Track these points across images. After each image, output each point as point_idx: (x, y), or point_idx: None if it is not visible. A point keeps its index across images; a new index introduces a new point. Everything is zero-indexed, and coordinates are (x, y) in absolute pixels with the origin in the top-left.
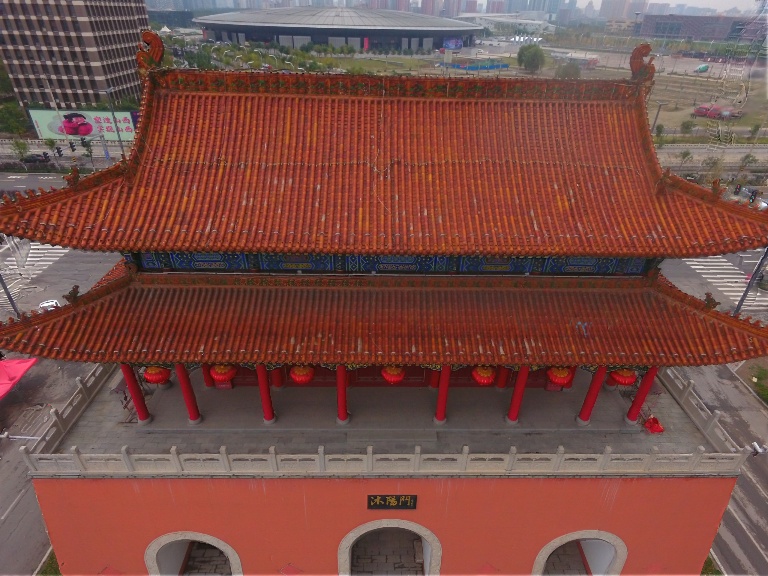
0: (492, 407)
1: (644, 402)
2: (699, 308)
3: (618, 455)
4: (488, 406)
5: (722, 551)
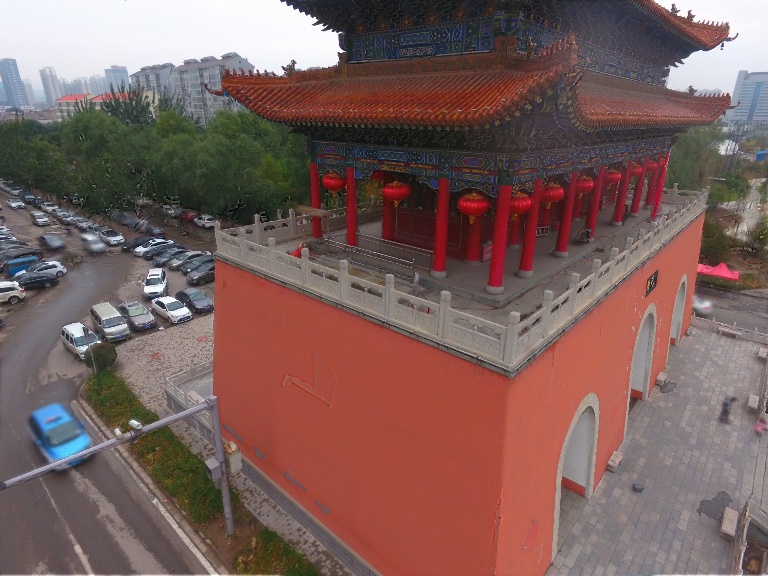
0: None
1: None
2: (297, 79)
3: None
4: None
5: (158, 533)
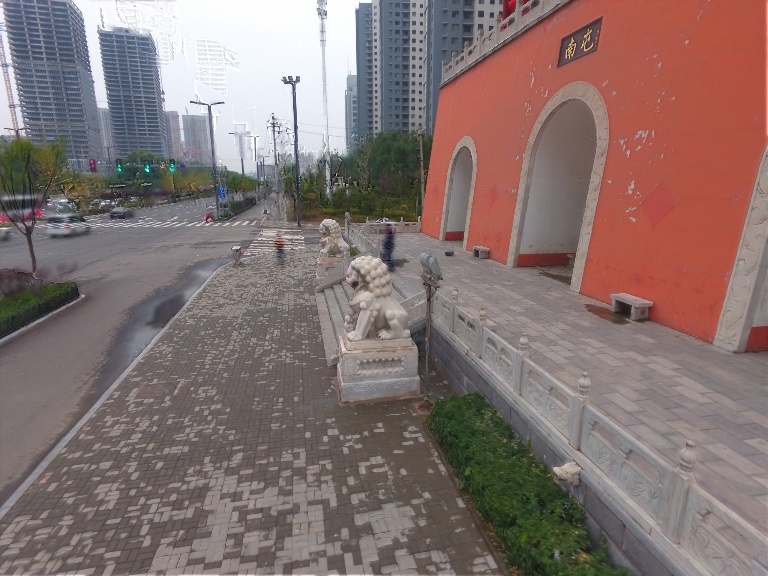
0: None
1: None
2: None
3: None
4: None
5: None
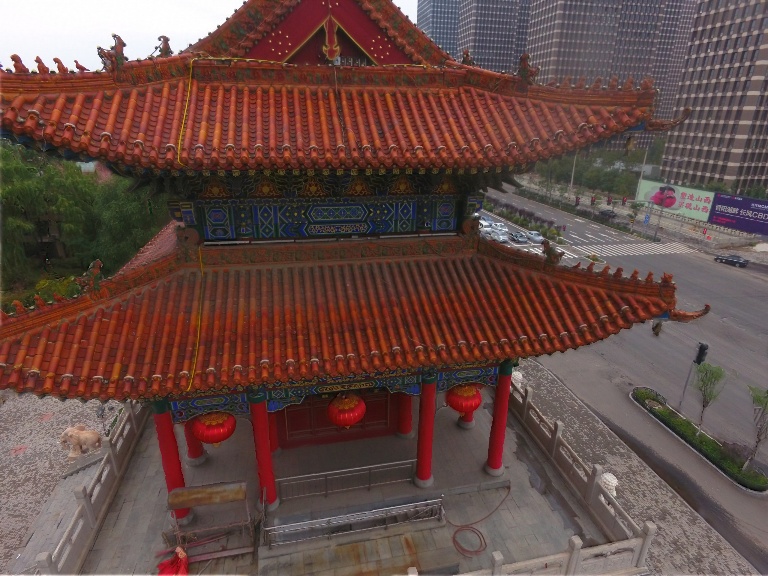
0: None
1: (238, 571)
2: None
3: None
4: None
5: None
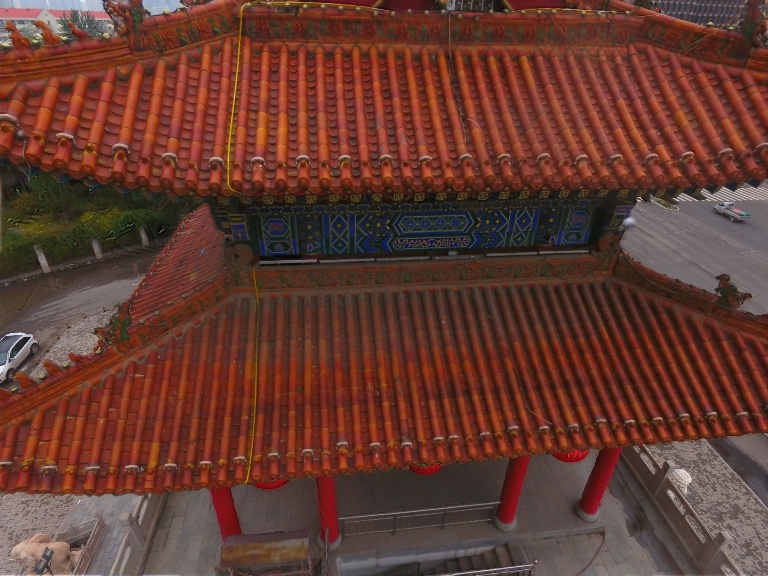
0: None
1: None
2: None
3: None
4: None
5: None
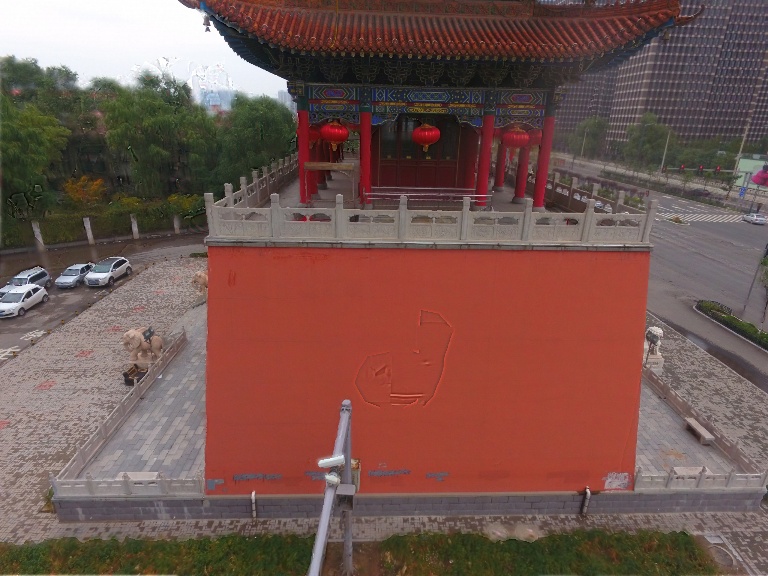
0: (339, 186)
1: None
2: None
3: (253, 183)
4: (340, 186)
5: None
